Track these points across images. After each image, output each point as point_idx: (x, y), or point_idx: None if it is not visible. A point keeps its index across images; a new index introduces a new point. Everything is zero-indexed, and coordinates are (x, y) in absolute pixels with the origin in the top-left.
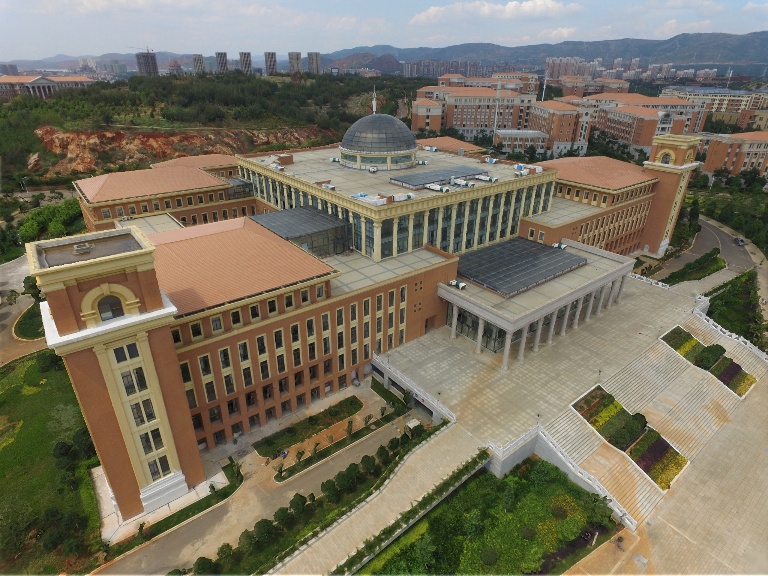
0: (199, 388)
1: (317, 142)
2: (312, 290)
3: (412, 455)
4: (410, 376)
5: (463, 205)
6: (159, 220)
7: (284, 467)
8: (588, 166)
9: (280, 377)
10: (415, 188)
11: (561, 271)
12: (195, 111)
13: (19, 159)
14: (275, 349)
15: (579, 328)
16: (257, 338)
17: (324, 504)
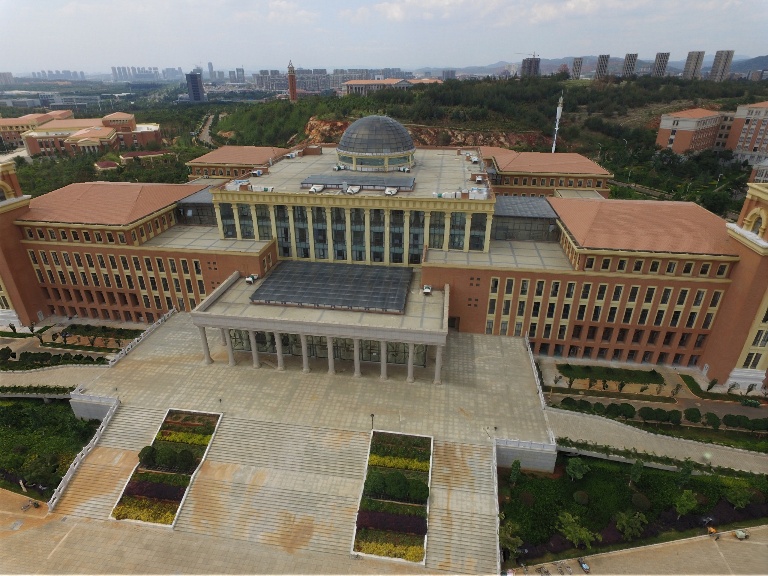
0: (43, 271)
1: (521, 149)
2: (114, 235)
3: (66, 368)
4: (161, 331)
5: (324, 211)
6: (218, 182)
7: (55, 341)
8: (617, 211)
9: (96, 289)
10: (302, 186)
11: (346, 306)
12: (413, 109)
13: (284, 136)
14: (88, 267)
15: (334, 376)
16: (74, 254)
17: (24, 366)
